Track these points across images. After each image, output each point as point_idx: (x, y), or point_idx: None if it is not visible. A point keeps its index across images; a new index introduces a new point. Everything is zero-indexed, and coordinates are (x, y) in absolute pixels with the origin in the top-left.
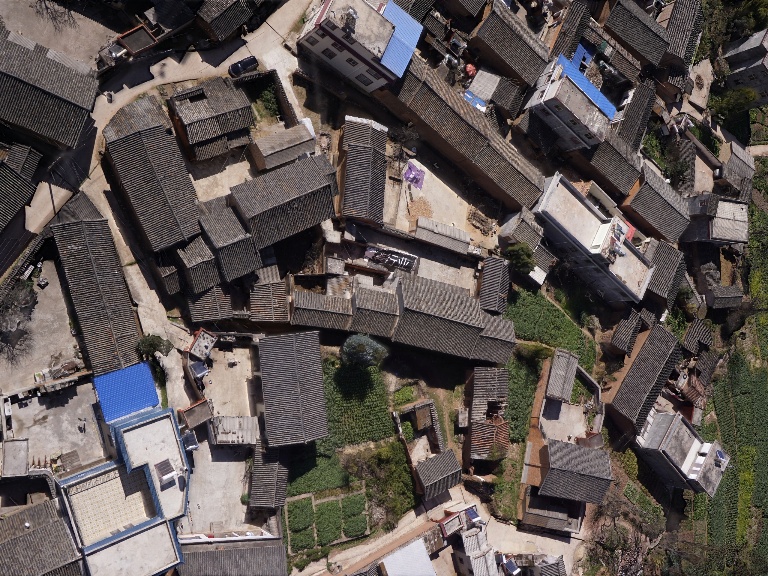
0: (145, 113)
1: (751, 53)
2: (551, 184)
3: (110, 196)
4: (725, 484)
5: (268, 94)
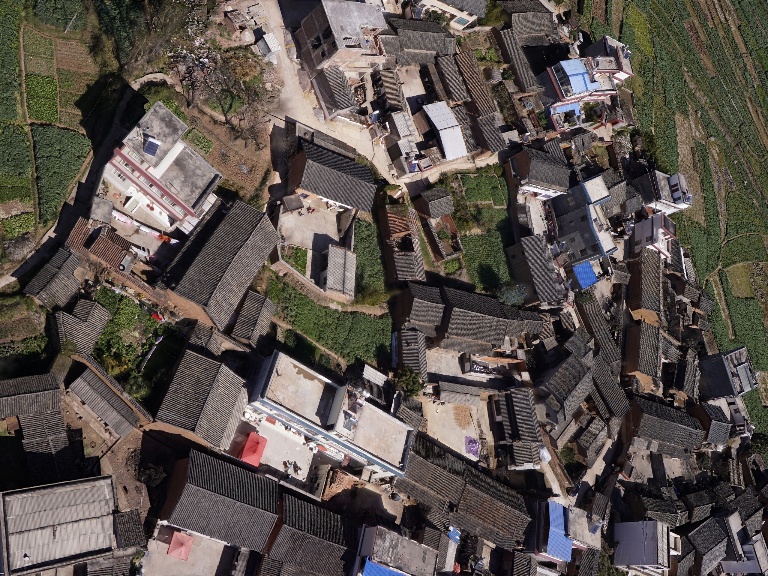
0: None
1: None
2: None
3: None
4: None
5: None
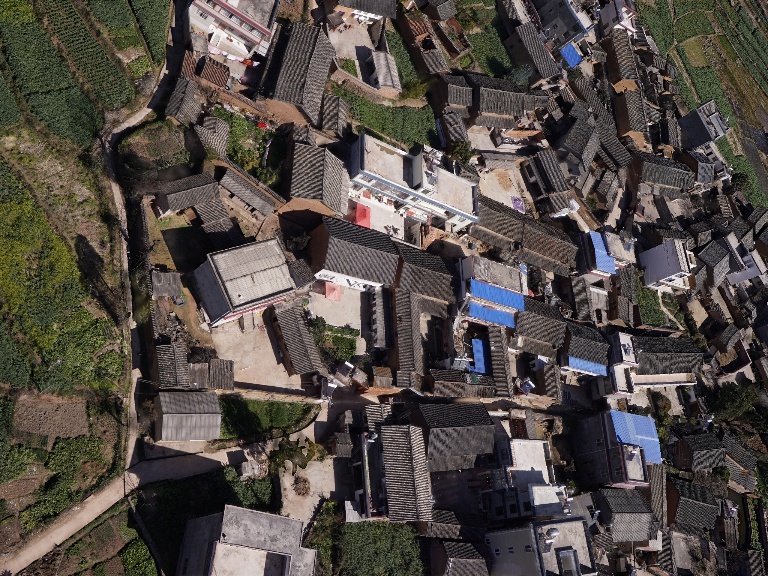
0: None
1: None
2: None
3: None
4: None
5: None
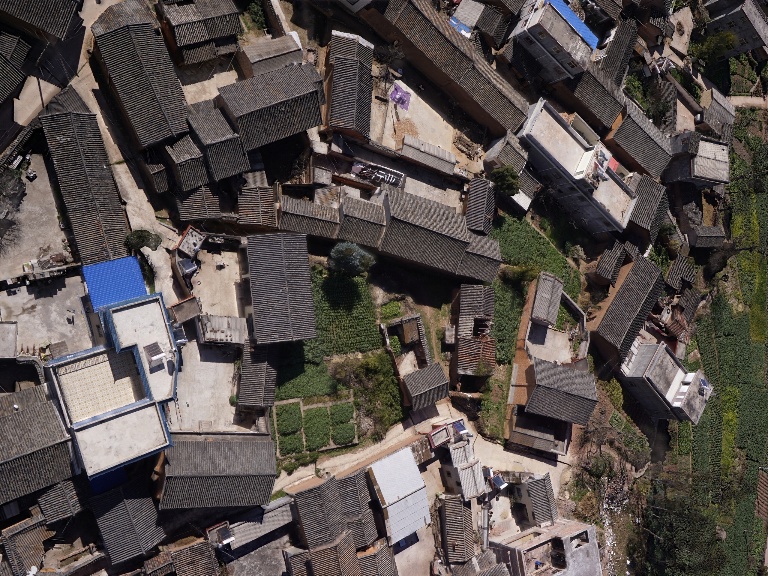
0: (133, 13)
1: (730, 0)
2: (535, 109)
3: (98, 95)
4: (709, 421)
5: (255, 6)
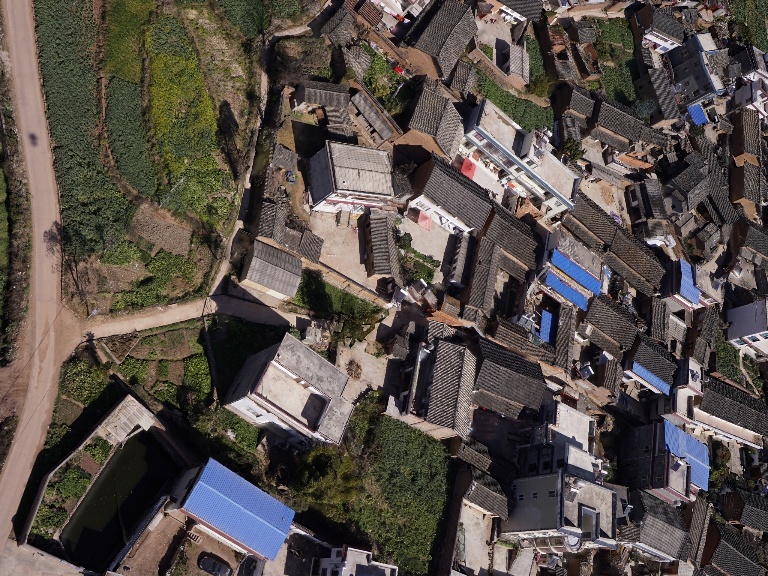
0: None
1: None
2: None
3: None
4: None
5: None
